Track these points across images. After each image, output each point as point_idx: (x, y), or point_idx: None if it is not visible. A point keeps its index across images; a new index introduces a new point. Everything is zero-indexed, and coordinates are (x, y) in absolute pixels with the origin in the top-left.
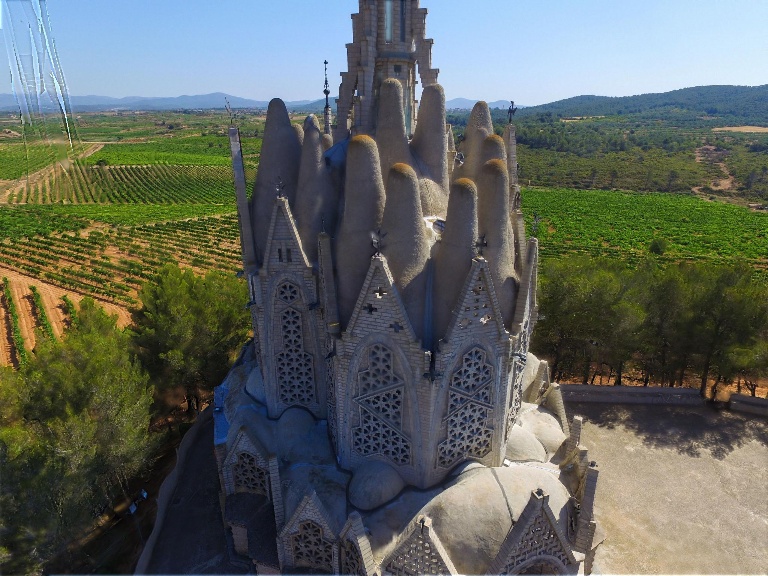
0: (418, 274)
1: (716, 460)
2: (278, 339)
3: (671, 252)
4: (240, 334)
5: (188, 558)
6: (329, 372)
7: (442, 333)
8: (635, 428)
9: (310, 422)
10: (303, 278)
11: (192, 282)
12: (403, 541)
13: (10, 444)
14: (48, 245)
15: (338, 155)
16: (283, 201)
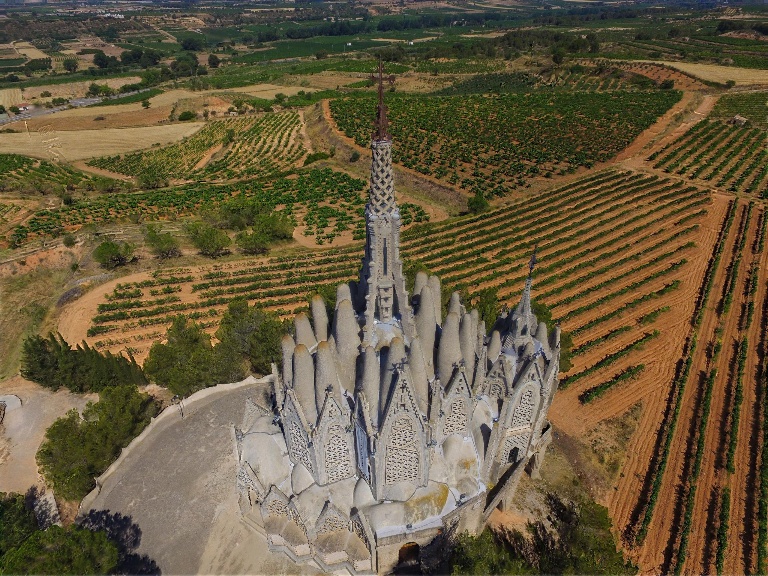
0: None
1: None
2: None
3: None
4: None
5: None
6: None
7: None
8: None
9: None
10: None
11: None
12: None
13: None
14: None
15: None
16: None
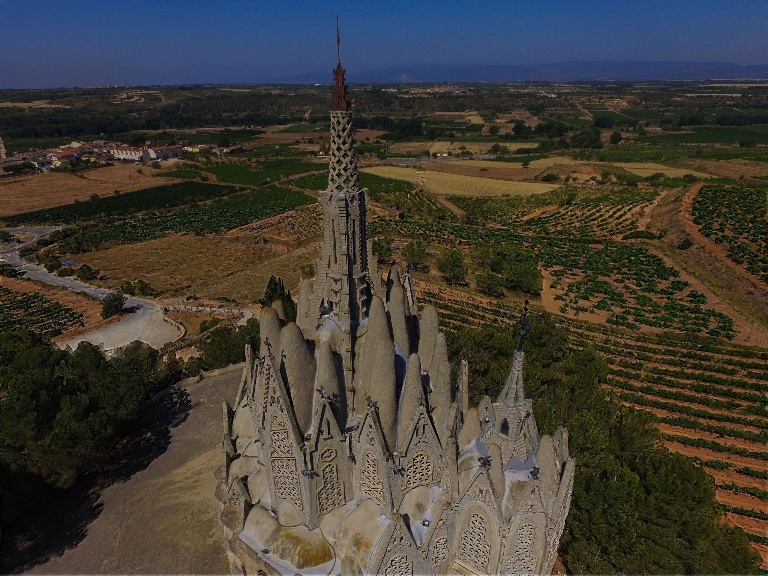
0: None
1: None
2: None
3: None
4: None
5: None
6: None
7: None
8: None
9: None
10: None
11: None
12: None
13: None
14: None
15: None
16: None
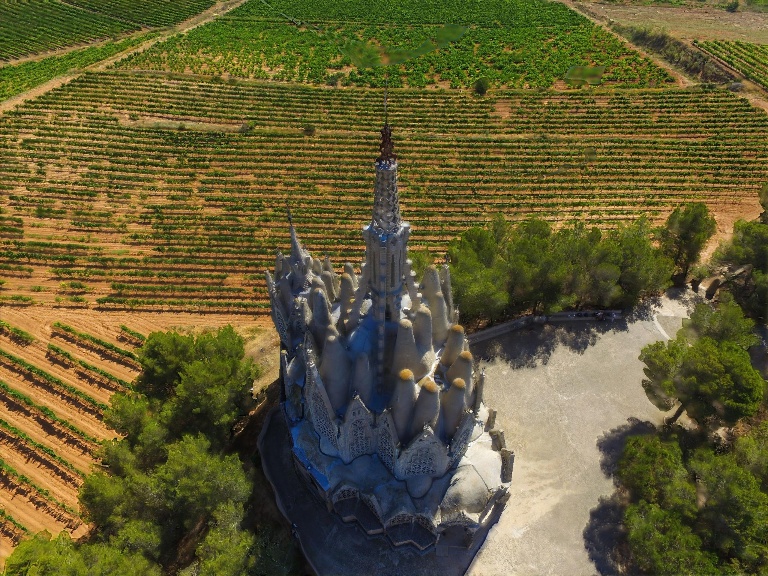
0: (438, 416)
1: (544, 365)
2: (351, 439)
3: (492, 91)
4: (245, 372)
5: (320, 534)
6: None
7: (450, 433)
8: (505, 356)
9: (369, 459)
10: (366, 416)
11: (185, 345)
12: (453, 517)
13: (226, 546)
14: None
15: (368, 346)
16: (358, 398)
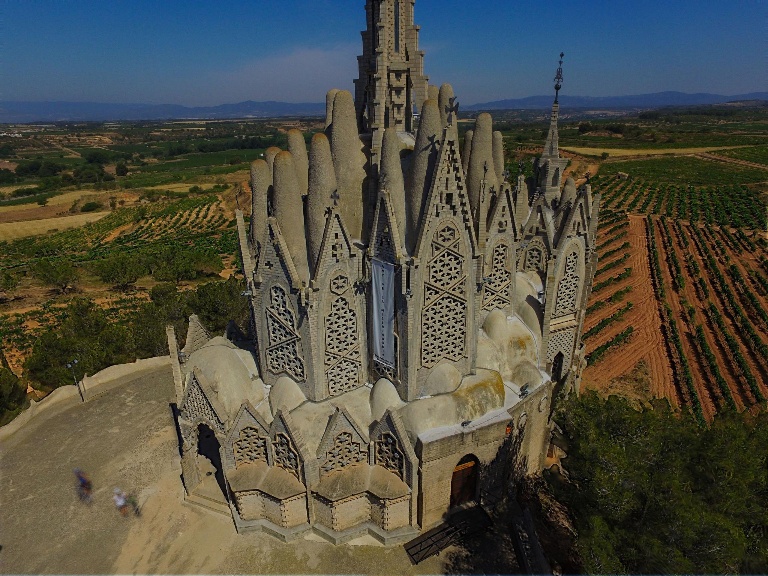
0: None
1: None
2: None
3: None
4: None
5: None
6: None
7: None
8: None
9: None
10: None
11: None
12: None
13: None
14: (709, 233)
15: None
16: None
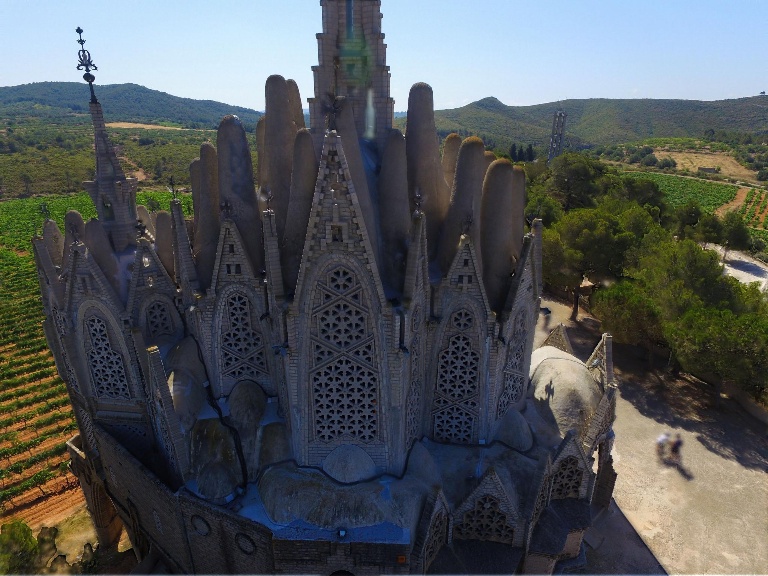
0: None
1: None
2: (408, 378)
3: None
4: None
5: None
6: (451, 375)
7: None
8: None
9: None
10: (422, 296)
11: None
12: (604, 412)
13: None
14: None
15: (372, 162)
16: None
